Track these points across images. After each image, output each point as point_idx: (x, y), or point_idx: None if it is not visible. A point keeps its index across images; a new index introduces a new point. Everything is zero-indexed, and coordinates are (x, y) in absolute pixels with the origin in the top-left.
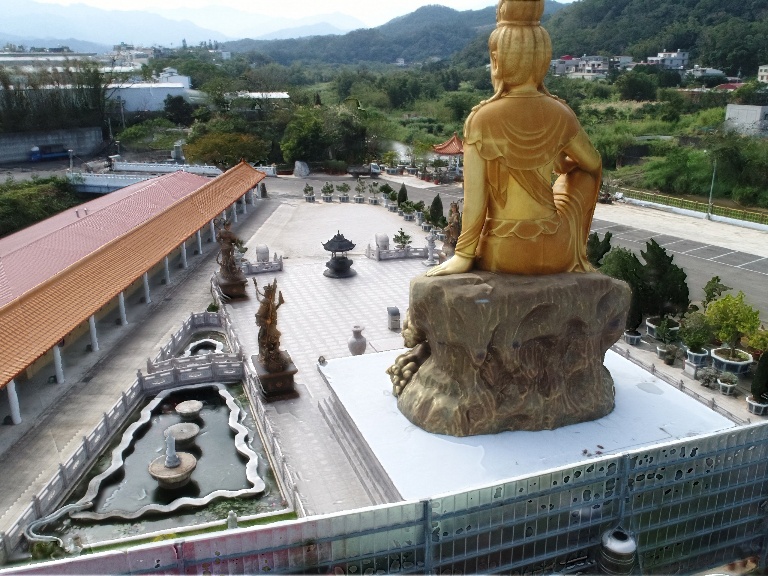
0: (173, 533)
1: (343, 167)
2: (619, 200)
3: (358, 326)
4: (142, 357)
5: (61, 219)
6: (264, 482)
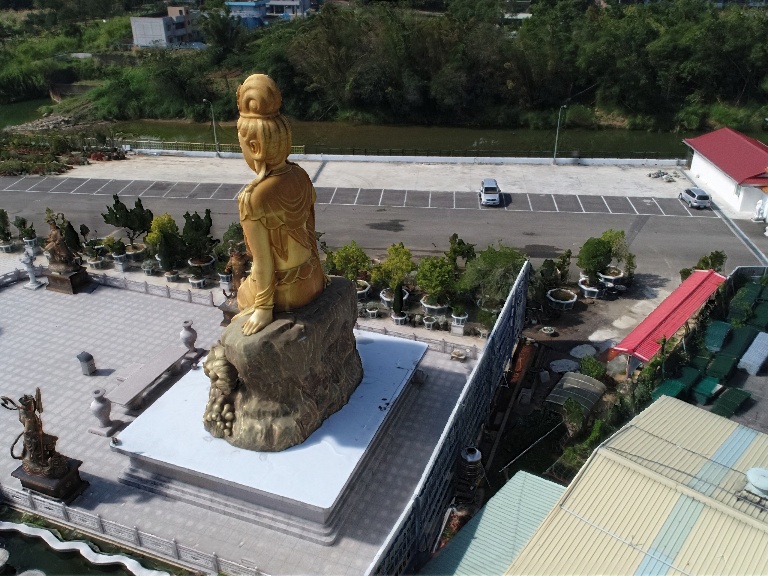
0: None
1: None
2: (129, 153)
3: (97, 391)
4: None
5: None
6: (164, 571)
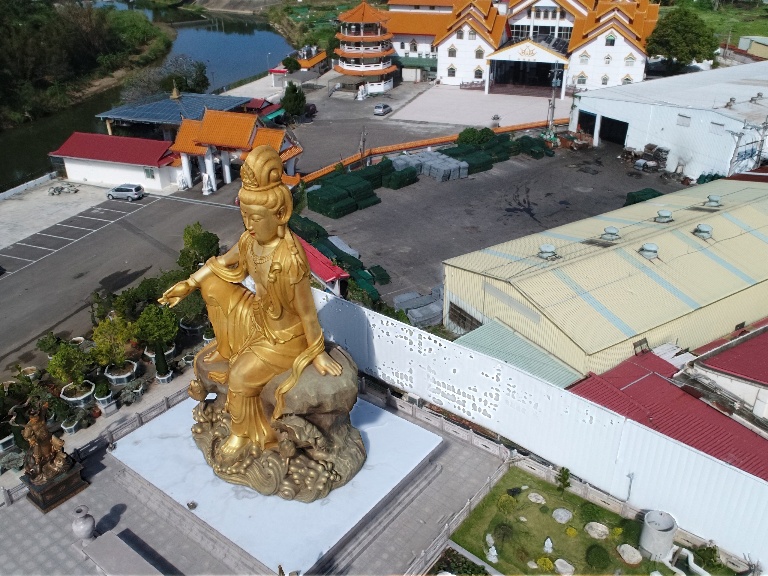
0: None
1: None
2: None
3: None
4: None
5: None
6: None
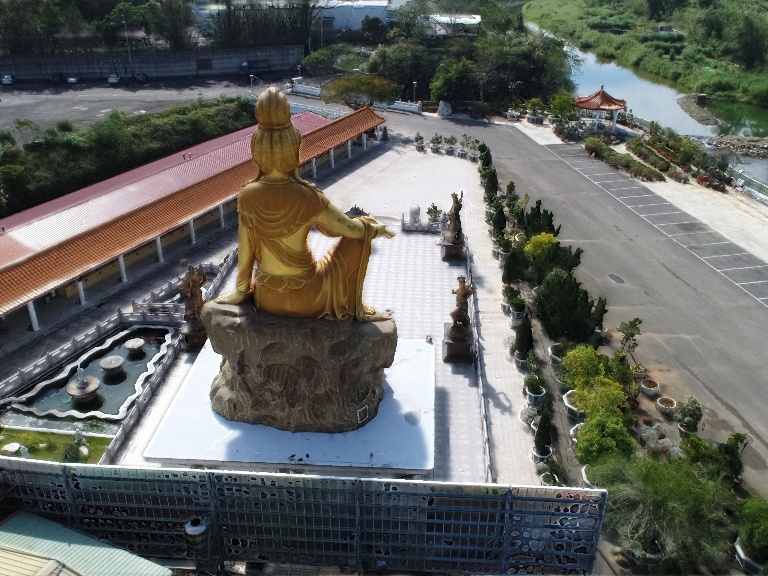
0: (50, 432)
1: (485, 110)
2: (737, 188)
3: None
4: (147, 294)
5: (181, 156)
6: (127, 413)
